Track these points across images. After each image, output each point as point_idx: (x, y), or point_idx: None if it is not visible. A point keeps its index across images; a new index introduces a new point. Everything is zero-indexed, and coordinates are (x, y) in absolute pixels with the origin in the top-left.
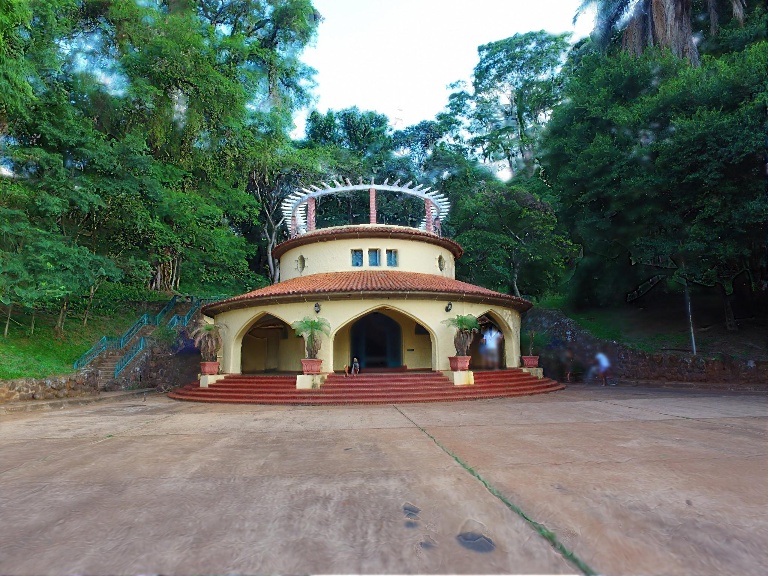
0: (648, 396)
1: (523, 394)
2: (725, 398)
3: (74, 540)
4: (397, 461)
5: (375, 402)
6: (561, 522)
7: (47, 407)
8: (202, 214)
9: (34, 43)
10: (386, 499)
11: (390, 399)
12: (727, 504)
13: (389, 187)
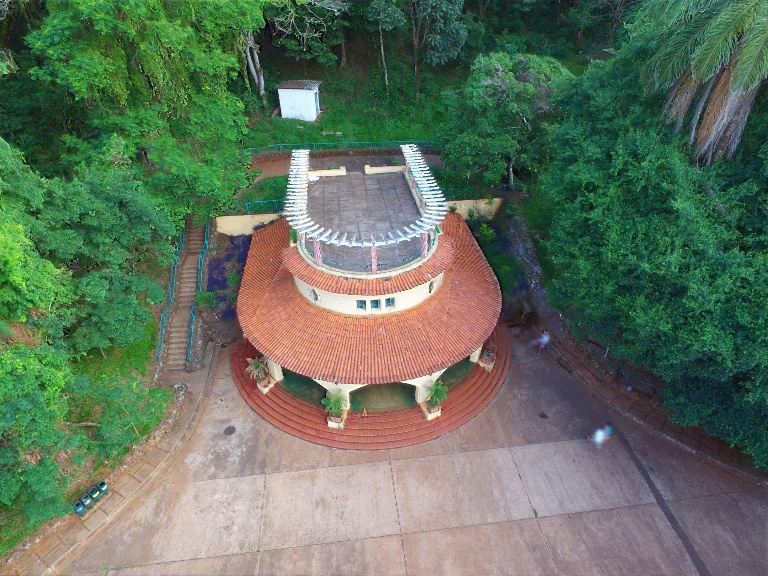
0: (545, 429)
1: (470, 419)
2: (585, 446)
3: None
4: None
5: (378, 449)
6: None
7: (180, 443)
8: (202, 191)
9: (1, 175)
10: None
11: (387, 446)
12: None
13: (389, 242)
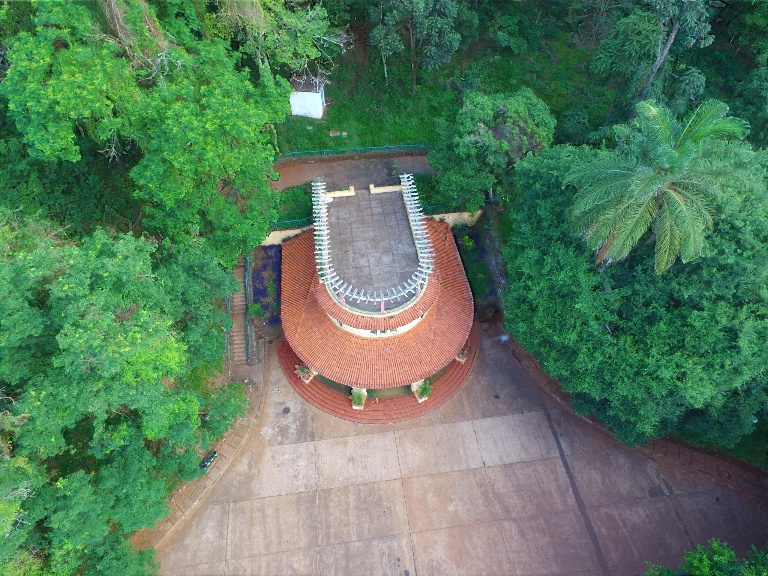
0: (497, 407)
1: (448, 400)
2: (521, 419)
3: (355, 574)
4: (396, 526)
5: (386, 423)
6: (419, 569)
7: (255, 421)
8: None
9: None
10: (395, 556)
11: (392, 421)
12: (446, 558)
13: None
